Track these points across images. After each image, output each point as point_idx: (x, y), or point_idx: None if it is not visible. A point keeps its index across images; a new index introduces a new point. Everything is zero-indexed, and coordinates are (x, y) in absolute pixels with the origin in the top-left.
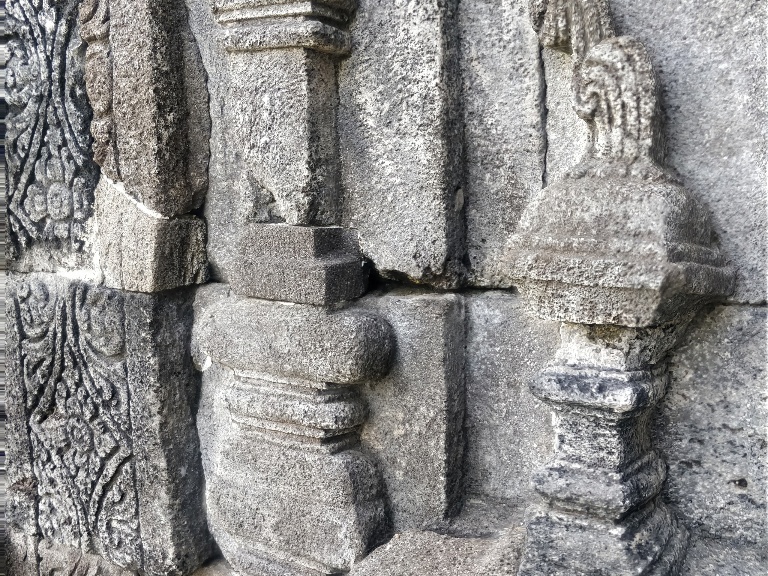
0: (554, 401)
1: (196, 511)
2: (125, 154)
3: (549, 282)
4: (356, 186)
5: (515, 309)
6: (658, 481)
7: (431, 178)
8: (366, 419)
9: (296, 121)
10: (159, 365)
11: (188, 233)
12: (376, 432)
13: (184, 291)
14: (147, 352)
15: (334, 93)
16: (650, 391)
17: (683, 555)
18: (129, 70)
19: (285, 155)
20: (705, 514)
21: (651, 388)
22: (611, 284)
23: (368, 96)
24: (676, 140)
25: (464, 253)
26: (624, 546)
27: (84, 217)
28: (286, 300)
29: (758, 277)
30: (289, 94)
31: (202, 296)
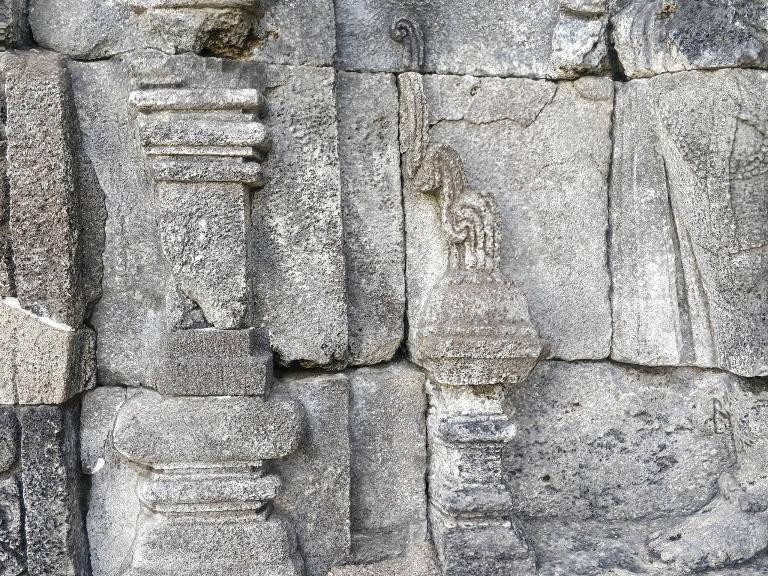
0: (461, 442)
1: None
2: (24, 270)
3: (460, 358)
4: (267, 293)
5: (387, 380)
6: None
7: (335, 285)
8: None
9: (234, 242)
10: (66, 474)
11: (83, 342)
12: (287, 496)
13: (73, 398)
14: (52, 463)
15: None
16: None
17: None
18: (35, 190)
19: (222, 271)
20: (526, 504)
21: None
22: (506, 356)
23: (279, 221)
24: None
25: None
26: (514, 533)
27: None
28: (222, 394)
29: (552, 342)
30: (227, 220)
31: (95, 401)
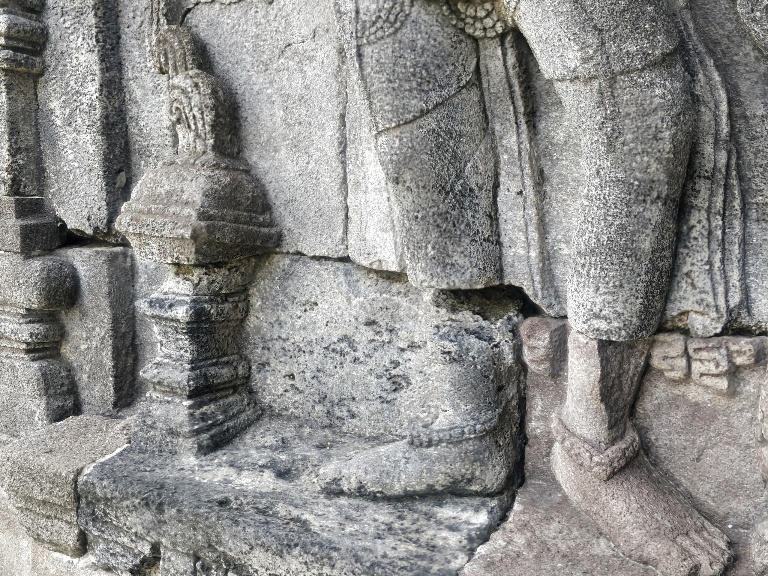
0: (150, 316)
1: None
2: None
3: (140, 235)
4: (52, 168)
5: None
6: (231, 374)
7: (96, 163)
8: (62, 337)
9: None
10: None
11: None
12: (70, 347)
13: None
14: None
15: (33, 101)
16: (212, 310)
17: (247, 424)
18: None
19: None
20: (272, 399)
21: (214, 308)
22: (168, 235)
23: (56, 104)
24: (246, 141)
25: None
26: (189, 412)
27: None
28: None
29: (292, 235)
30: None
31: None
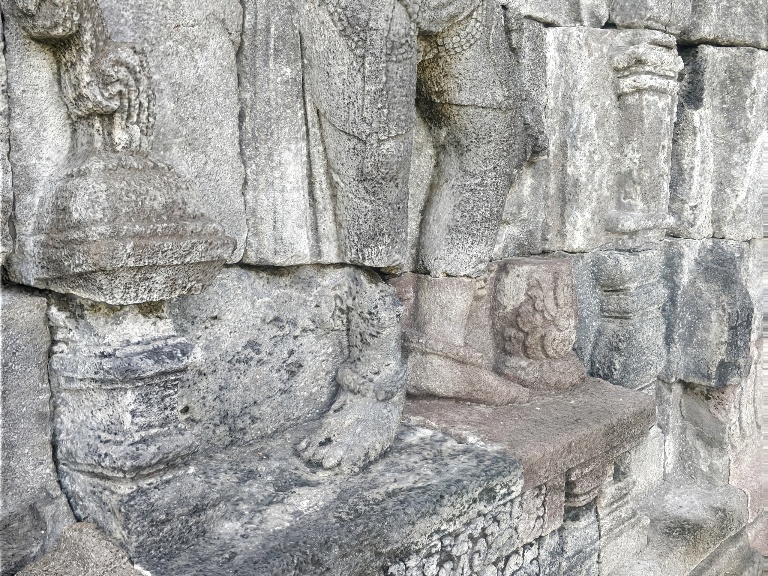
0: None
1: None
2: None
3: (142, 267)
4: None
5: None
6: None
7: None
8: None
9: None
10: None
11: None
12: None
13: None
14: None
15: None
16: None
17: None
18: None
19: None
20: None
21: None
22: (196, 260)
23: None
24: None
25: None
26: (200, 478)
27: None
28: None
29: None
30: None
31: None
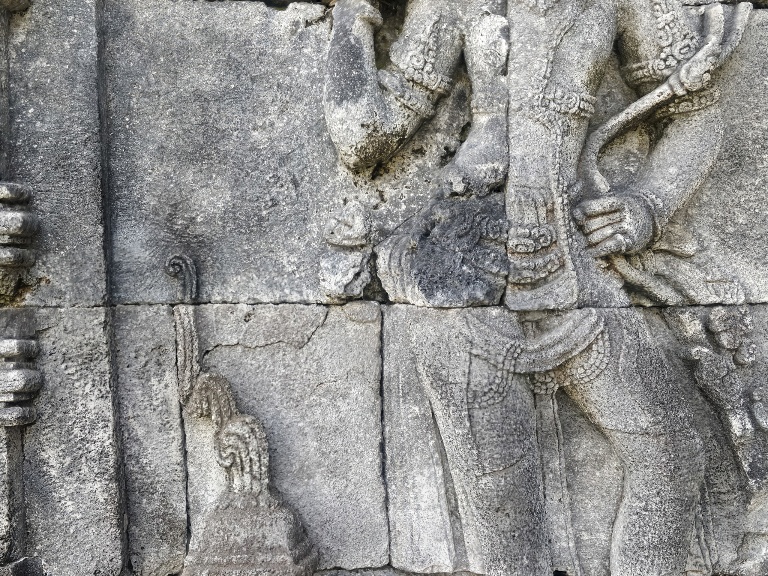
0: None
1: None
2: None
3: None
4: (40, 523)
5: None
6: None
7: (108, 512)
8: None
9: None
10: None
11: None
12: None
13: None
14: None
15: (21, 453)
16: None
17: None
18: None
19: None
20: None
21: None
22: None
23: (51, 453)
24: (276, 470)
25: (128, 560)
26: None
27: None
28: None
29: (331, 553)
30: None
31: None
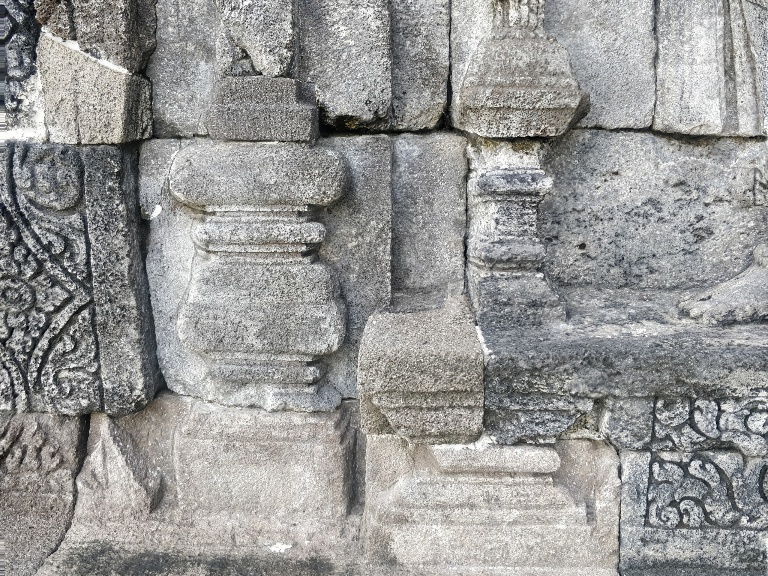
0: (498, 193)
1: (150, 347)
2: (82, 12)
3: (500, 109)
4: (313, 47)
5: (429, 144)
6: None
7: (380, 41)
8: None
9: None
10: (126, 211)
11: (139, 91)
12: (332, 247)
13: (131, 146)
14: (113, 200)
15: None
16: None
17: None
18: None
19: (269, 16)
20: (561, 270)
21: None
22: (545, 106)
23: None
24: None
25: None
26: (546, 283)
27: (25, 75)
28: (269, 140)
29: (594, 110)
30: None
31: (152, 149)
